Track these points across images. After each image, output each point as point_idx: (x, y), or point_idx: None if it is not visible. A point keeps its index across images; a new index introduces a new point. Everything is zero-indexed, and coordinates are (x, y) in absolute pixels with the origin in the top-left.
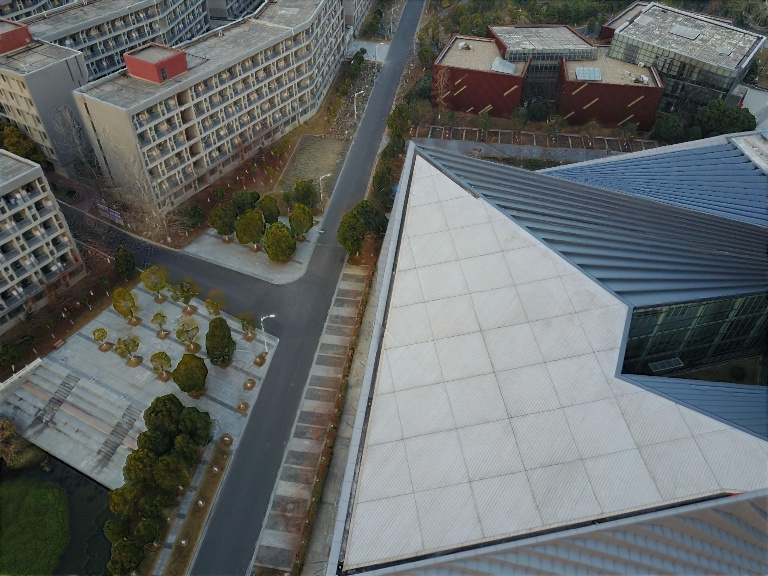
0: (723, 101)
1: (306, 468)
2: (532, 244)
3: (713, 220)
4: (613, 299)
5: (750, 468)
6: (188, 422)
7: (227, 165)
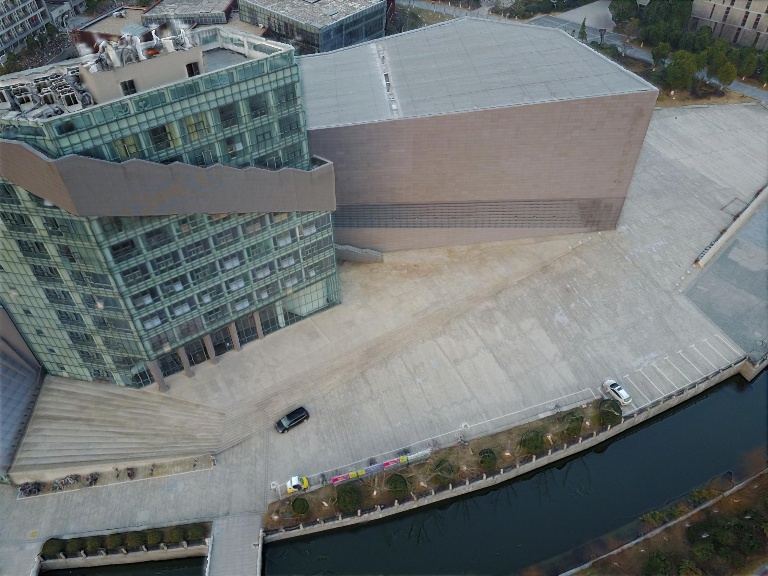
0: None
1: None
2: None
3: None
4: None
5: None
6: None
7: None
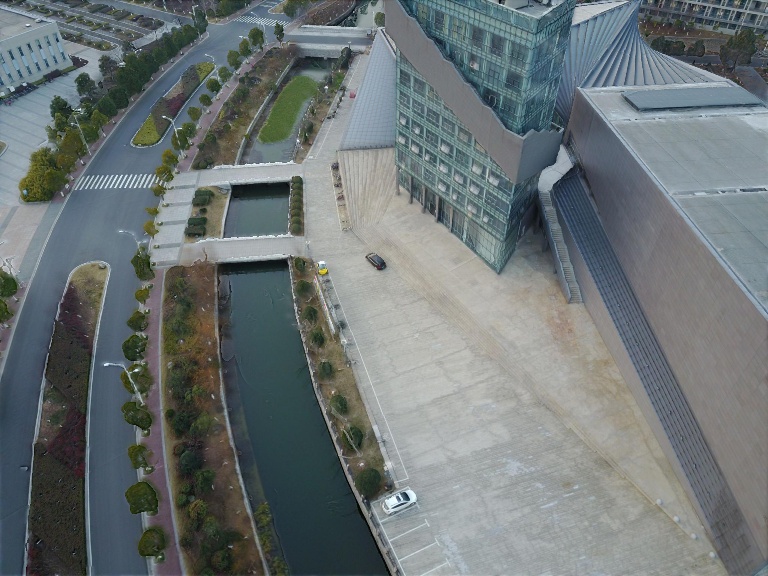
0: None
1: None
2: None
3: None
4: None
5: None
6: None
7: (654, 15)
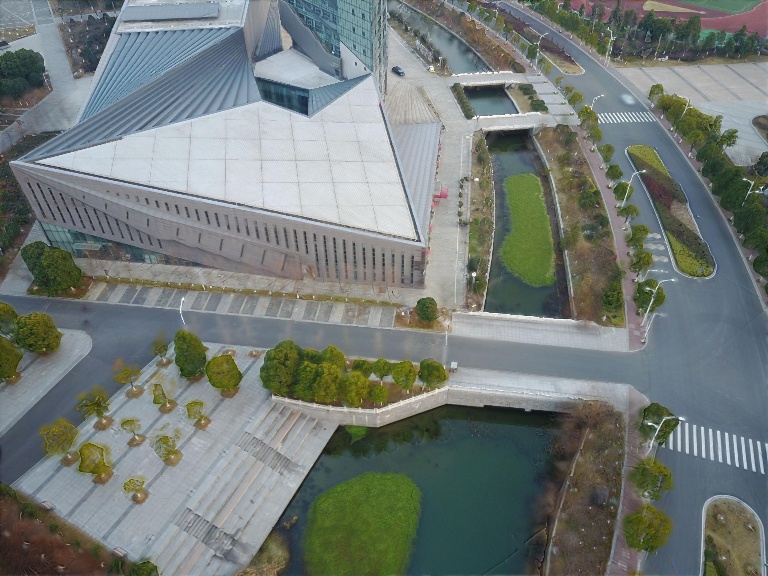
0: (9, 51)
1: (319, 308)
2: (190, 123)
3: (202, 56)
4: (253, 104)
5: (368, 95)
6: (292, 346)
7: None
